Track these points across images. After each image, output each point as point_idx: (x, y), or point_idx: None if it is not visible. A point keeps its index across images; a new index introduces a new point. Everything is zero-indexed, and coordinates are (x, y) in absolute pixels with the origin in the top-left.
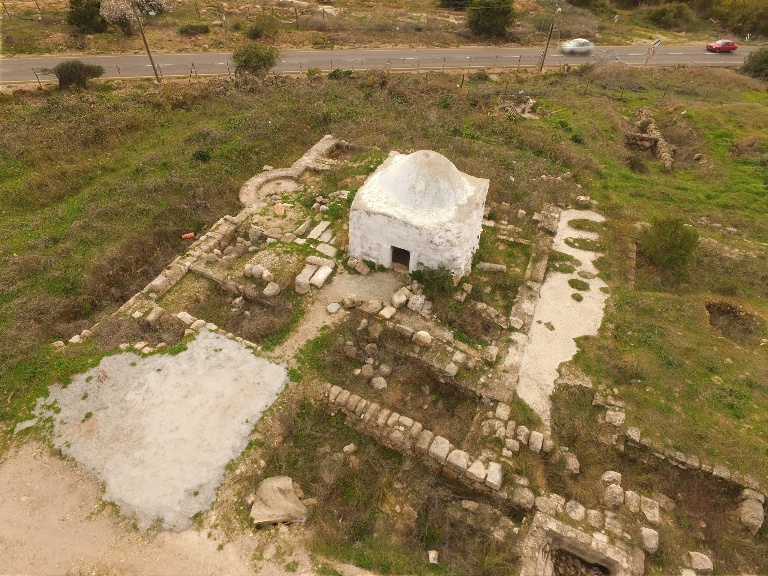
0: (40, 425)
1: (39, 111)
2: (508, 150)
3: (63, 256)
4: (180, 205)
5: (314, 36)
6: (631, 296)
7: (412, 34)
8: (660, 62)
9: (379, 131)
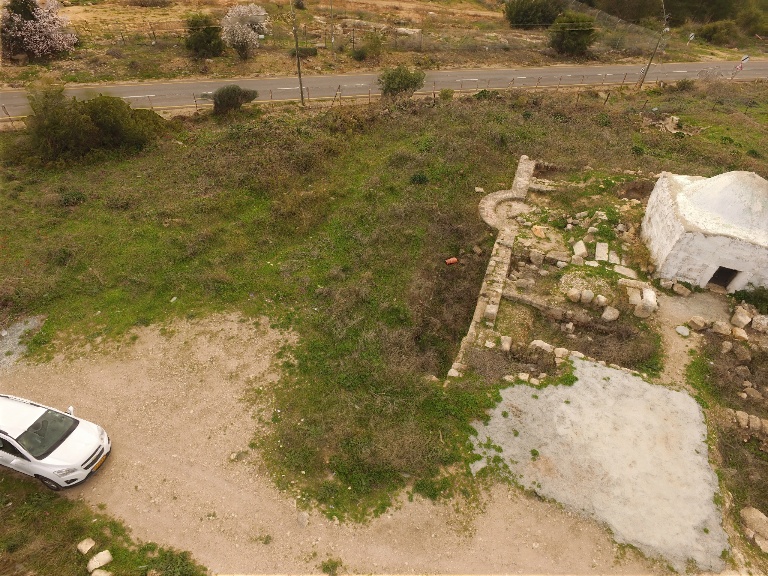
0: (492, 465)
1: (227, 137)
2: (698, 167)
3: (369, 286)
4: None
5: (414, 57)
6: None
7: (502, 54)
8: (738, 77)
9: (569, 151)
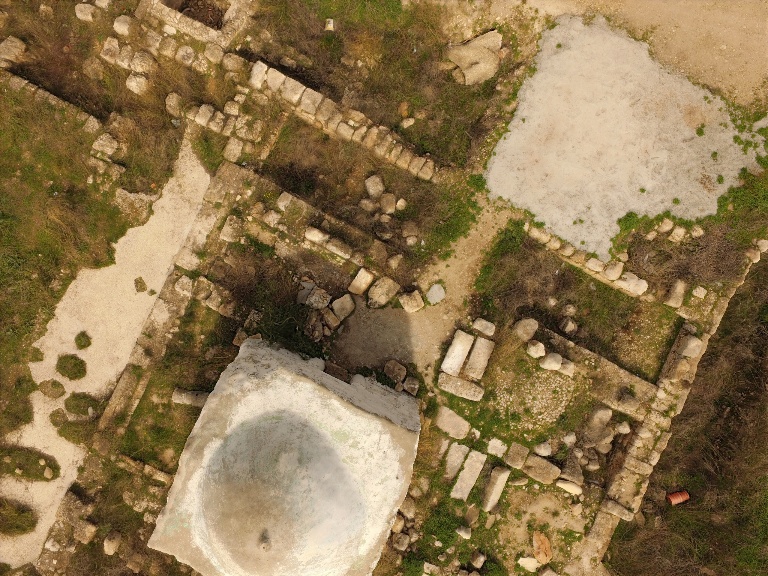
0: (747, 123)
1: None
2: None
3: None
4: (718, 571)
5: None
6: (2, 342)
7: None
8: None
9: None
